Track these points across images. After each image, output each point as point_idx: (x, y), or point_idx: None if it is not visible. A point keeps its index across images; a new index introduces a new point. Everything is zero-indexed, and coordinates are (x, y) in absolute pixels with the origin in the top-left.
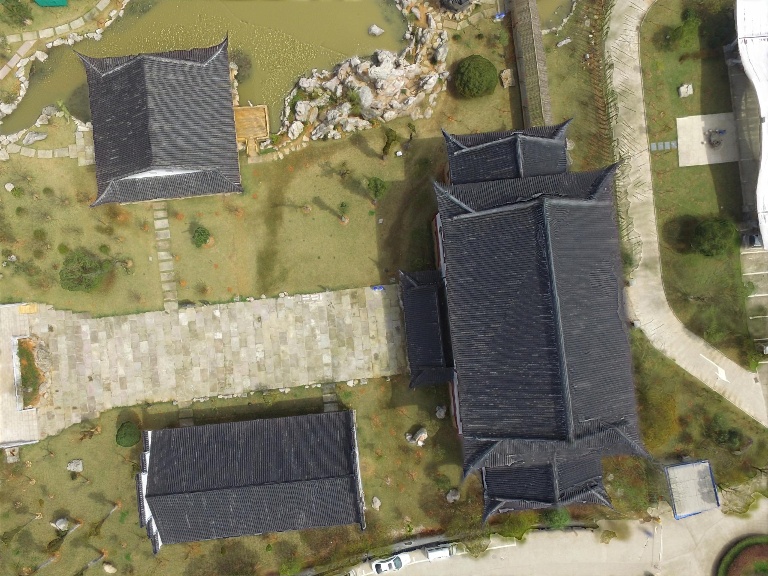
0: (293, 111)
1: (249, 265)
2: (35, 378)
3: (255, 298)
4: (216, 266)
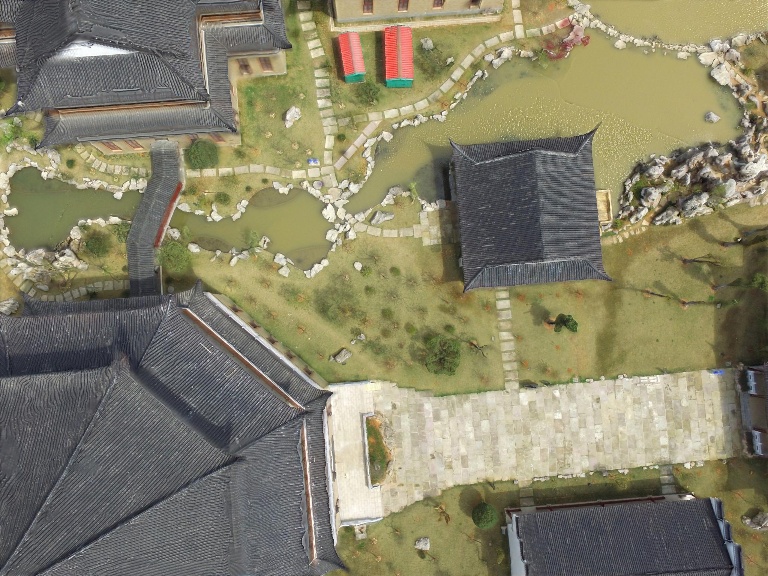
0: (637, 196)
1: (589, 347)
2: (383, 456)
3: (594, 379)
4: (557, 347)
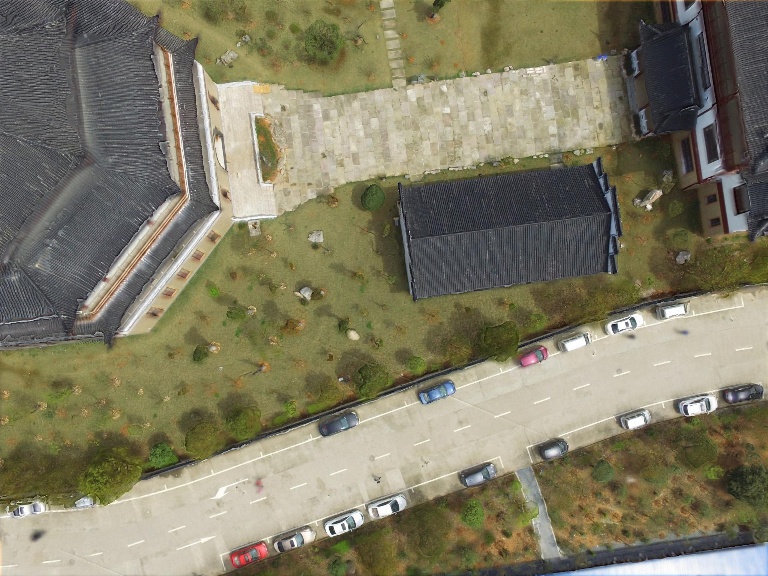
0: None
1: (474, 41)
2: (273, 153)
3: (481, 73)
4: (442, 42)
